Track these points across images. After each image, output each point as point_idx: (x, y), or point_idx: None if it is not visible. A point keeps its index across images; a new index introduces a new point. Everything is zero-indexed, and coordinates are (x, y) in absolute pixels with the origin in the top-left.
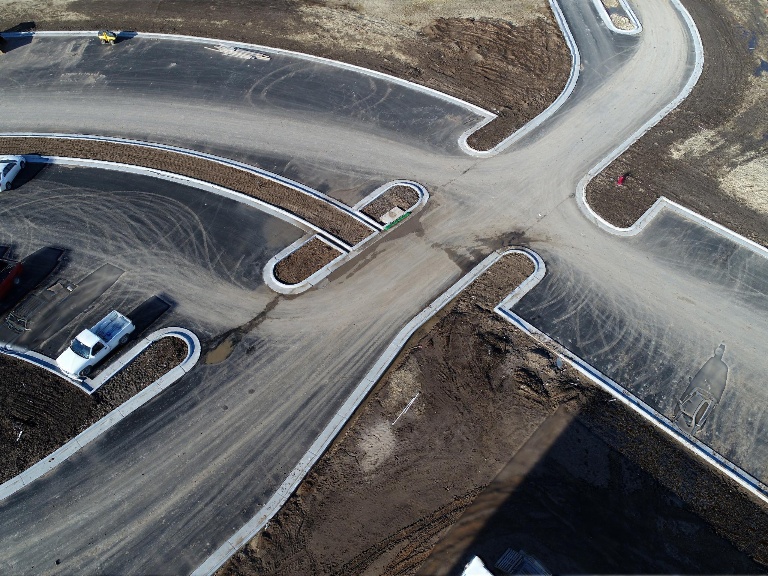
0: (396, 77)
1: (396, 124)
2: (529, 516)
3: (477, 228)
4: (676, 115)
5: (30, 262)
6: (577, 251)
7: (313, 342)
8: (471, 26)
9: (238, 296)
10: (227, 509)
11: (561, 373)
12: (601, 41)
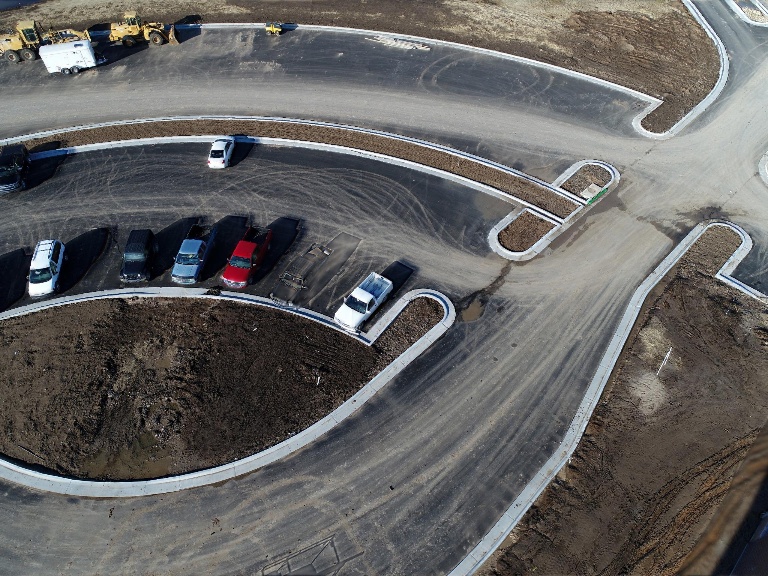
0: (555, 66)
1: (568, 109)
2: None
3: (675, 203)
4: None
5: (272, 230)
6: None
7: (556, 303)
8: (612, 19)
9: (472, 262)
10: (528, 445)
11: None
12: (740, 33)
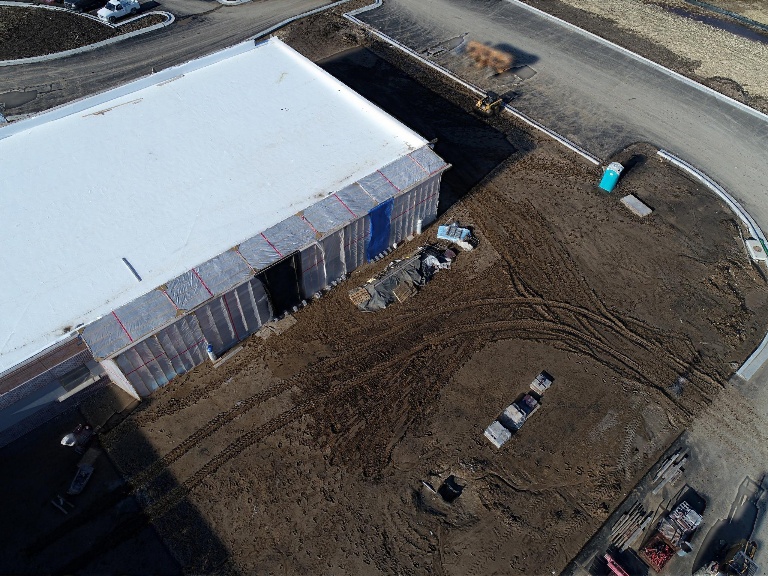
0: None
1: None
2: None
3: None
4: None
5: None
6: None
7: (237, 21)
8: None
9: (200, 4)
10: None
11: (369, 37)
12: None
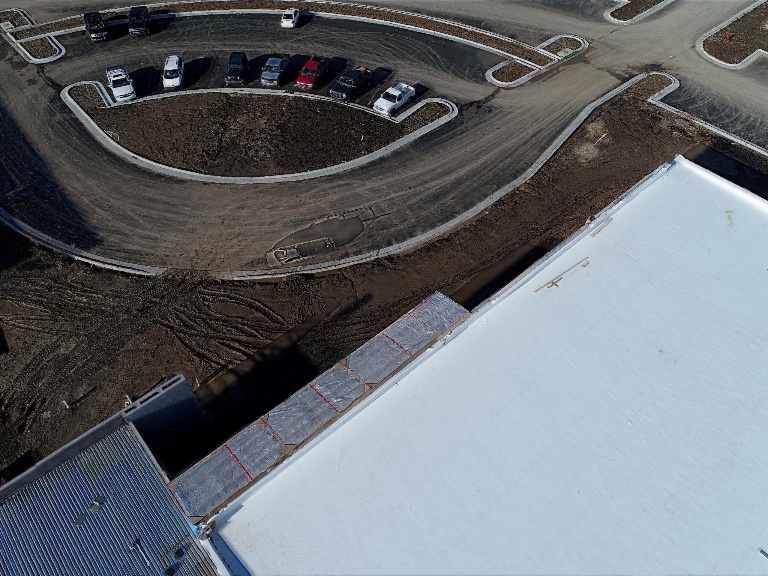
0: None
1: (555, 4)
2: None
3: (627, 61)
4: (766, 6)
5: None
6: (700, 75)
7: (530, 109)
8: None
9: (473, 86)
10: (501, 174)
11: (699, 130)
12: None
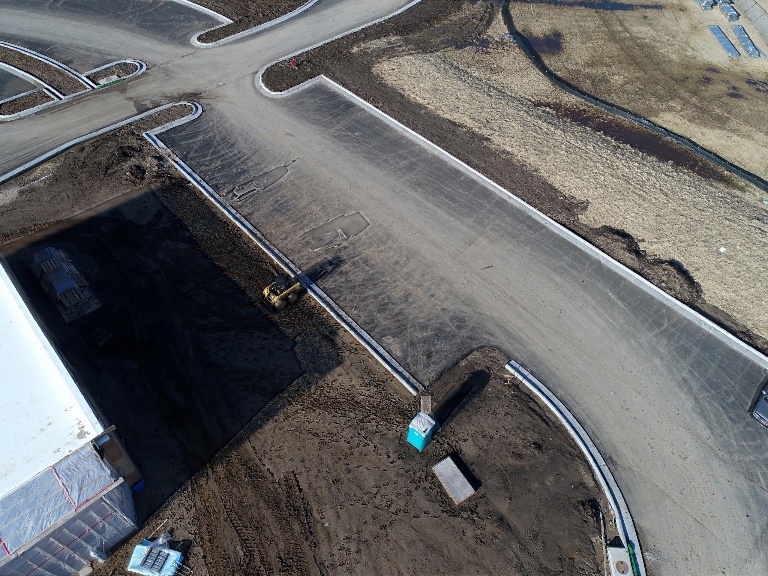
0: None
1: (151, 25)
2: (78, 235)
3: (167, 89)
4: (377, 25)
5: None
6: (232, 105)
7: None
8: None
9: None
10: None
11: (163, 169)
12: None
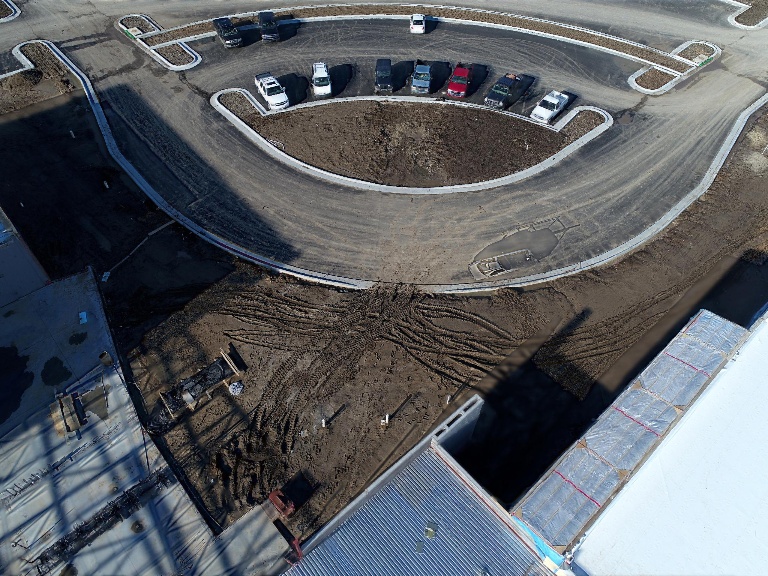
0: None
1: (676, 9)
2: None
3: (766, 68)
4: None
5: None
6: None
7: (684, 117)
8: None
9: (619, 94)
10: (677, 184)
11: None
12: None
